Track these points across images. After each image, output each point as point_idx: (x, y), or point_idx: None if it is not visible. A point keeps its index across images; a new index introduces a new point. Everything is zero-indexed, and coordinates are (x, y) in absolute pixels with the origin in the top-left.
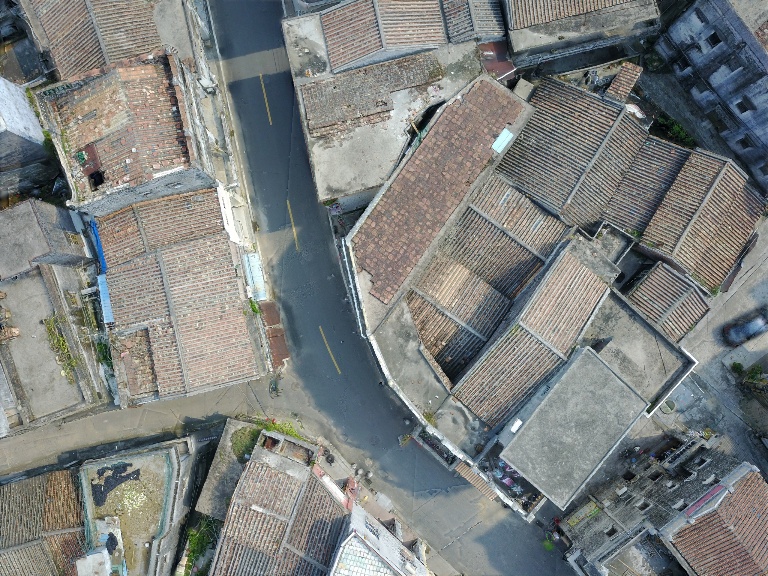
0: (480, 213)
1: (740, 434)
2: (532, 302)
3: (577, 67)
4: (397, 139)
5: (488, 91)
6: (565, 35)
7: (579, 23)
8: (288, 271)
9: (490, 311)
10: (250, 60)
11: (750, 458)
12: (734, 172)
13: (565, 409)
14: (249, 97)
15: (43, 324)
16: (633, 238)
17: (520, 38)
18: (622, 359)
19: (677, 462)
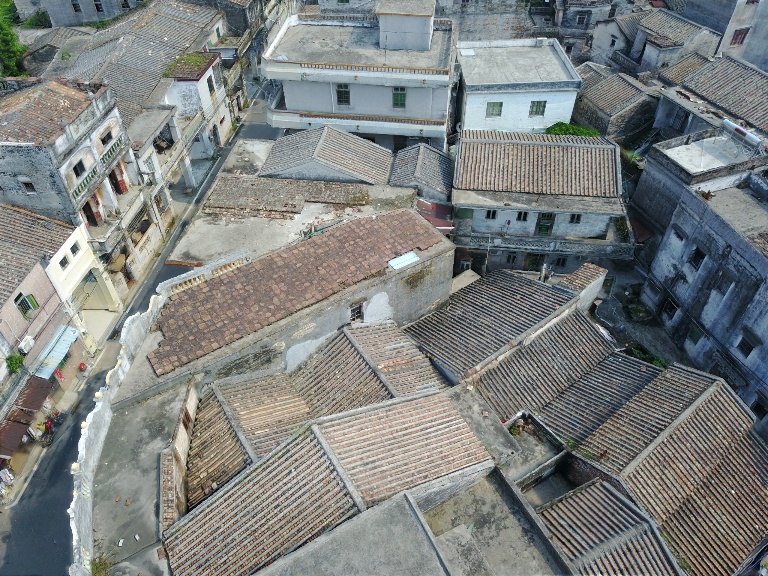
0: (353, 342)
1: None
2: (351, 414)
3: None
4: (289, 235)
5: (407, 218)
6: (513, 204)
7: (531, 199)
8: None
9: None
10: None
11: None
12: (730, 400)
13: None
14: None
15: None
16: (564, 444)
17: (463, 196)
18: (475, 564)
19: None
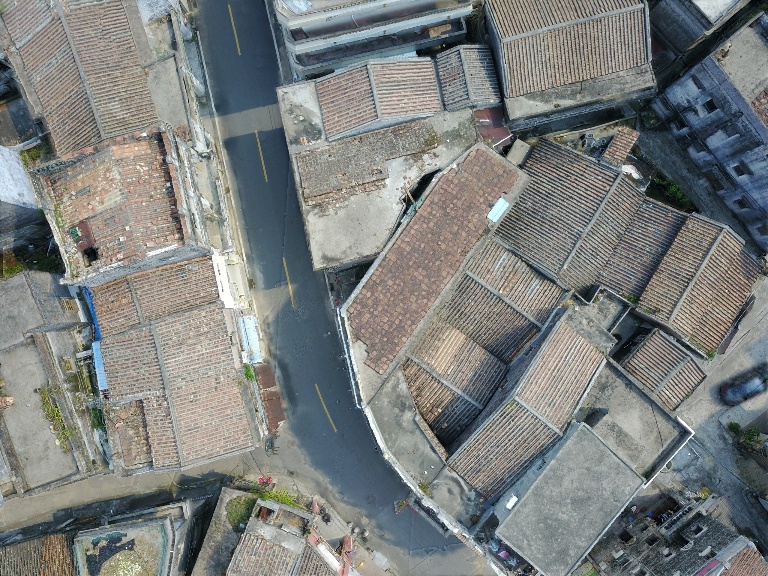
0: (476, 279)
1: (737, 493)
2: (528, 376)
3: (574, 125)
4: (392, 207)
5: (484, 160)
6: (561, 103)
7: (575, 91)
8: (284, 328)
9: (486, 377)
10: (246, 116)
11: (747, 517)
12: (731, 238)
13: (561, 486)
14: (245, 154)
15: (37, 393)
16: (629, 303)
17: (516, 106)
18: (618, 432)
19: (674, 529)
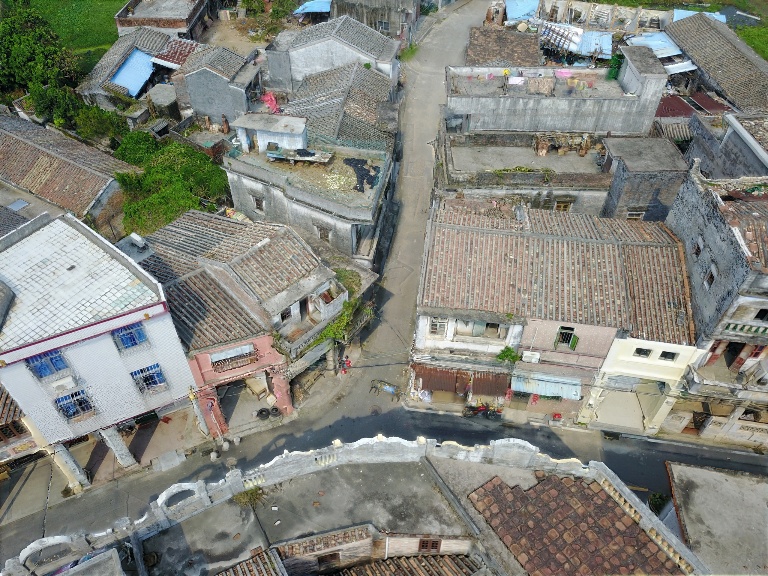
0: None
1: None
2: None
3: None
4: None
5: None
6: None
7: None
8: None
9: None
10: None
11: None
12: None
13: None
14: None
15: None
16: None
17: None
18: None
19: None
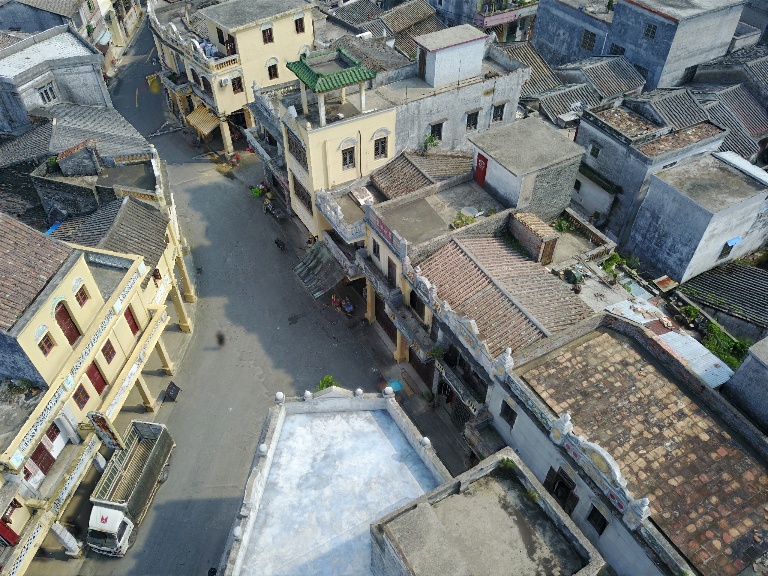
0: None
1: None
2: None
3: None
4: None
5: None
6: None
7: None
8: (133, 69)
9: None
10: None
11: None
12: (425, 4)
13: (254, 2)
14: None
15: None
16: None
17: None
18: None
19: None
